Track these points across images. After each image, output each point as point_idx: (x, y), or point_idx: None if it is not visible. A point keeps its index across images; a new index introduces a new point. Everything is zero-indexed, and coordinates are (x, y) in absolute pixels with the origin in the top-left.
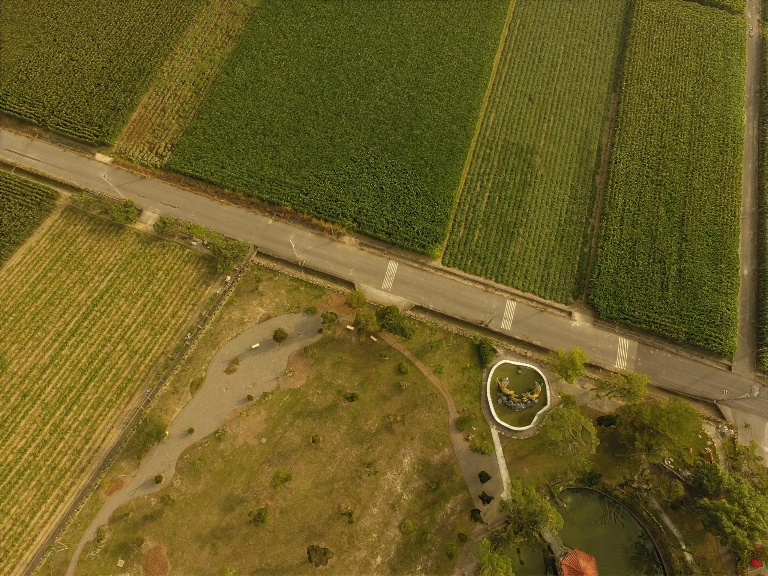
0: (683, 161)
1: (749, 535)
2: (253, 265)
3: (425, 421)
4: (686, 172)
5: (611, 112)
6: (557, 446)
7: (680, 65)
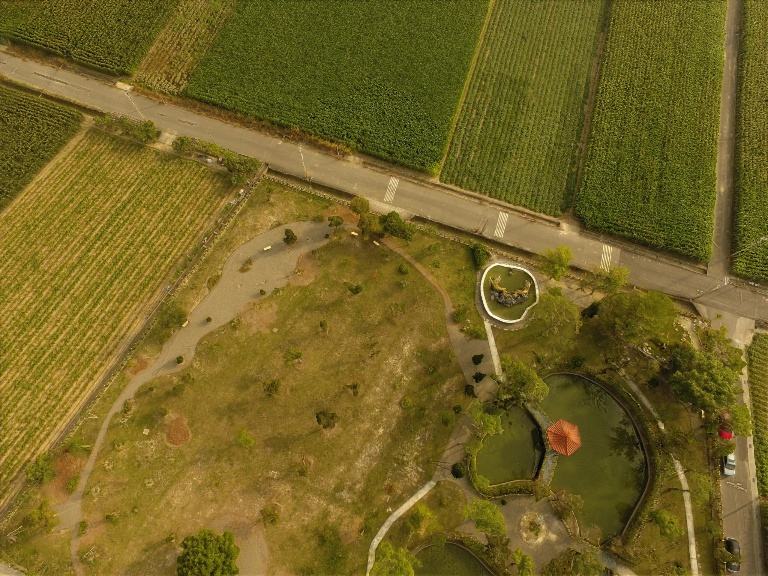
0: (665, 91)
1: (716, 398)
2: (264, 180)
3: (423, 314)
4: (668, 101)
5: (599, 49)
6: (545, 337)
7: (664, 7)
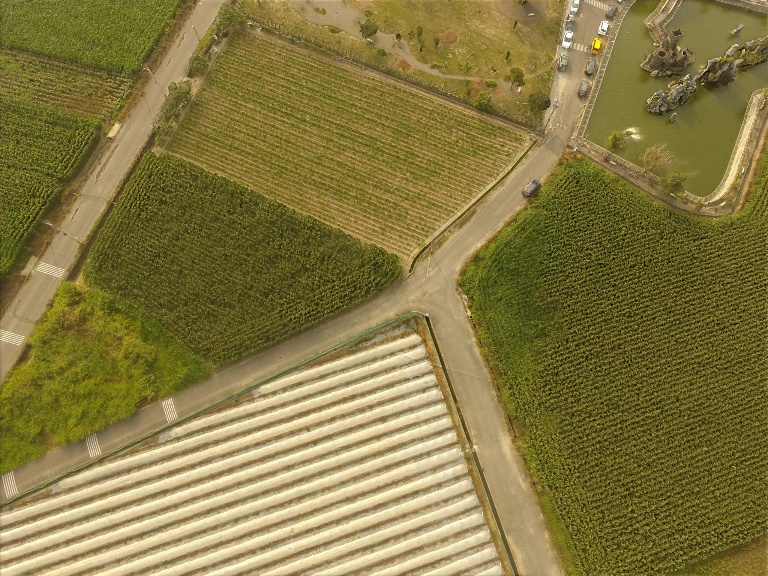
0: None
1: None
2: None
3: None
4: None
5: None
6: None
7: None
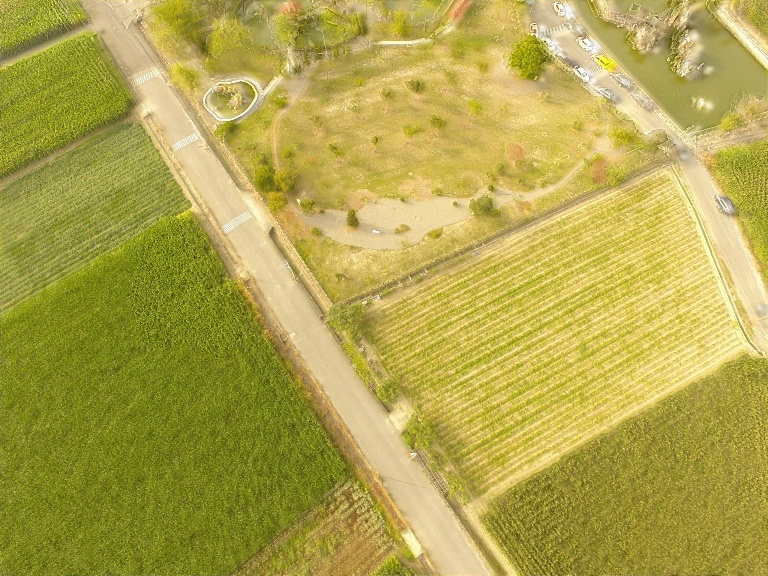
0: None
1: None
2: None
3: (300, 121)
4: None
5: None
6: None
7: None
